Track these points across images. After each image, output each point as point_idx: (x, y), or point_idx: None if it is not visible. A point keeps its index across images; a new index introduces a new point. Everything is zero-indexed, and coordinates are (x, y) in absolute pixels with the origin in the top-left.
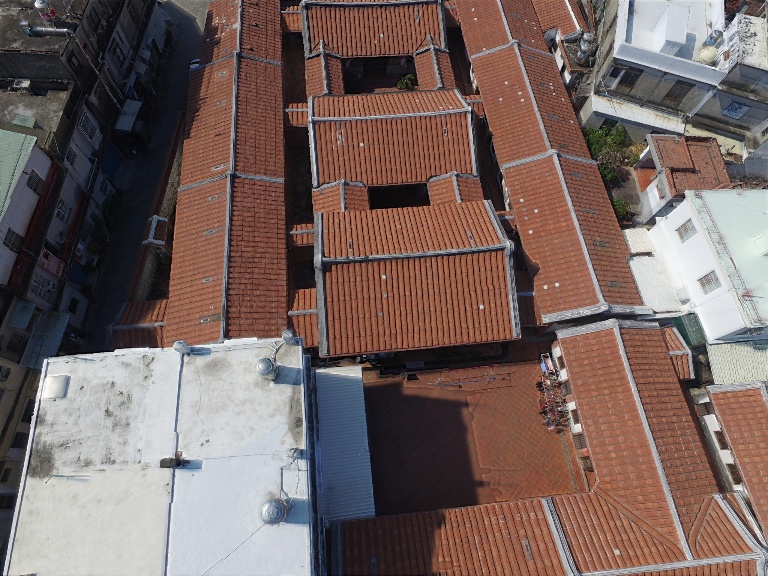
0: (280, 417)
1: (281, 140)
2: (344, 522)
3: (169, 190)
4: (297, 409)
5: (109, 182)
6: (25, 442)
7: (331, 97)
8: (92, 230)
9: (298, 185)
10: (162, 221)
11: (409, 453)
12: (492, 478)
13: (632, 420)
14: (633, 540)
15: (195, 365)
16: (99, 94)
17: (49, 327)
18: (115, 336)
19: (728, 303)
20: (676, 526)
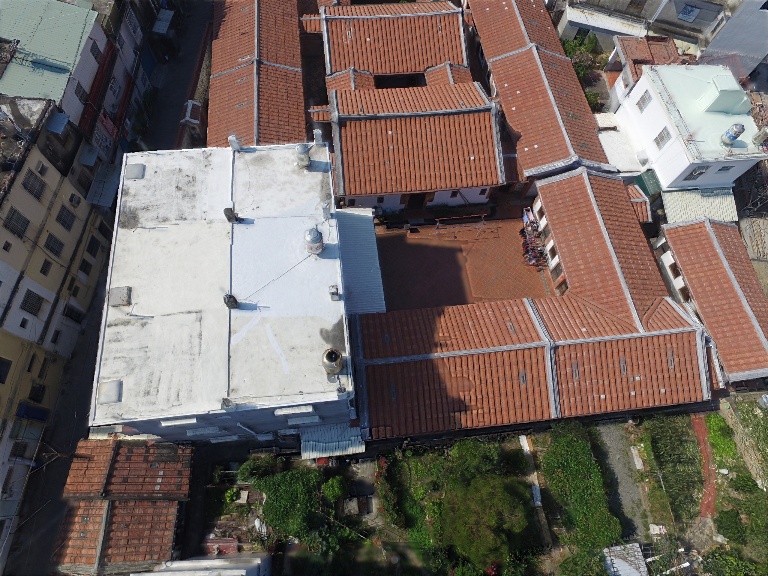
0: (313, 193)
1: (297, 40)
2: (361, 314)
3: (200, 85)
4: (326, 188)
5: (147, 78)
6: (89, 271)
7: (340, 6)
8: (135, 113)
9: (311, 85)
10: (196, 105)
11: (413, 286)
12: None
13: (597, 240)
14: (597, 323)
15: (244, 159)
16: None
17: (108, 175)
18: None
19: (677, 150)
20: (632, 311)
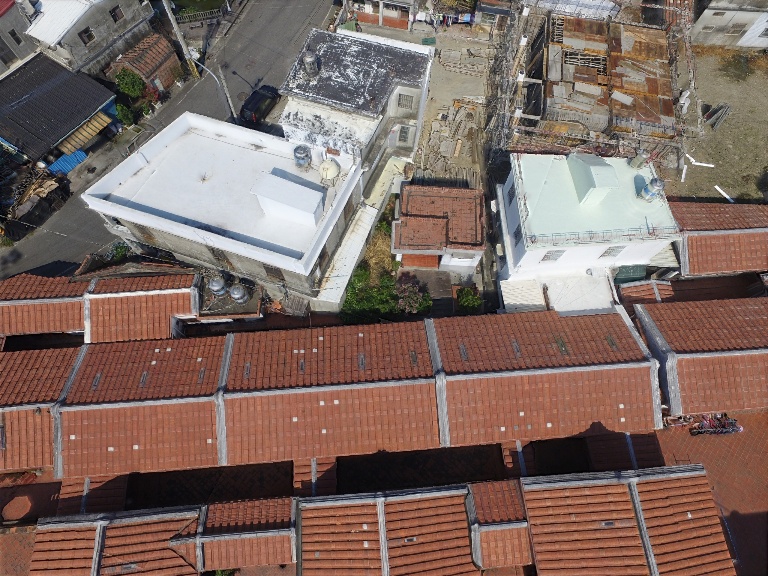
0: None
1: None
2: None
3: None
4: None
5: None
6: None
7: None
8: None
9: None
10: None
11: None
12: None
13: (765, 362)
14: None
15: None
16: None
17: None
18: None
19: None
20: None
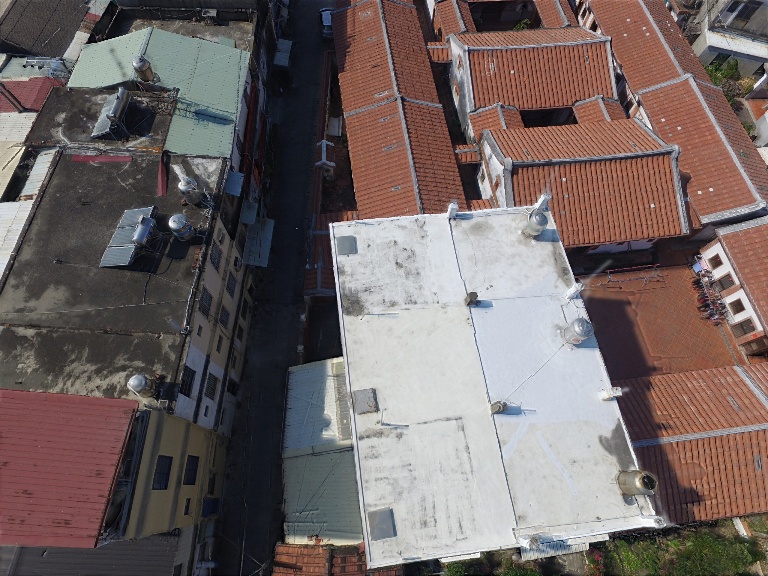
0: (548, 267)
1: (430, 72)
2: None
3: None
4: (561, 261)
5: (269, 114)
6: (241, 337)
7: (470, 34)
8: (265, 155)
9: None
10: (330, 145)
11: None
12: (663, 364)
13: None
14: None
15: (462, 227)
16: (265, 29)
17: None
18: (314, 241)
19: None
20: None
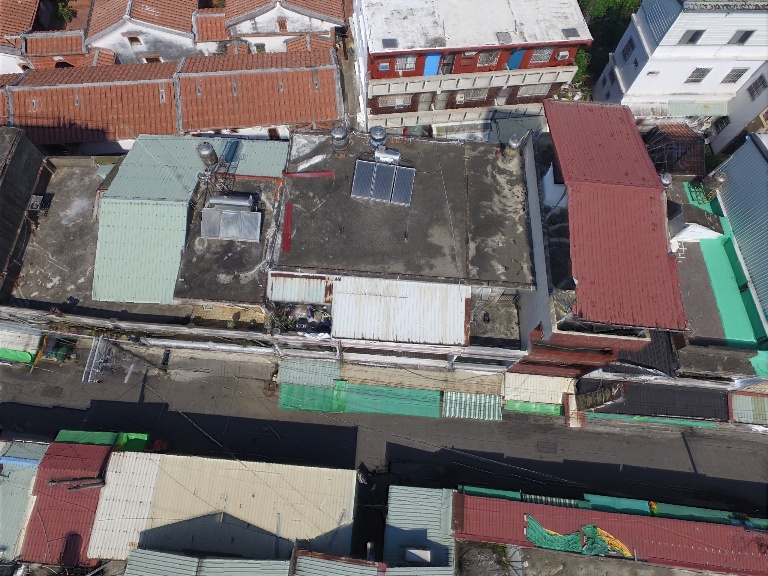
0: None
1: None
2: None
3: None
4: None
5: None
6: None
7: (89, 28)
8: None
9: None
10: None
11: None
12: None
13: None
14: None
15: None
16: None
17: None
18: None
19: None
20: None
